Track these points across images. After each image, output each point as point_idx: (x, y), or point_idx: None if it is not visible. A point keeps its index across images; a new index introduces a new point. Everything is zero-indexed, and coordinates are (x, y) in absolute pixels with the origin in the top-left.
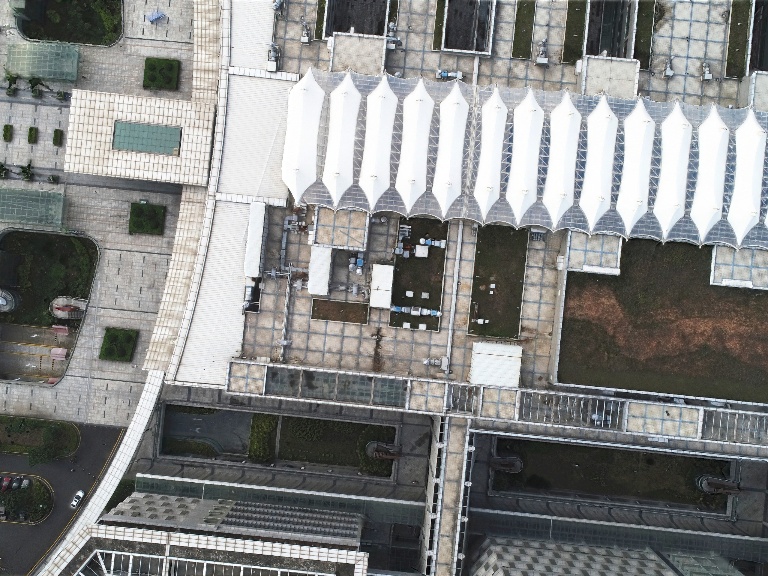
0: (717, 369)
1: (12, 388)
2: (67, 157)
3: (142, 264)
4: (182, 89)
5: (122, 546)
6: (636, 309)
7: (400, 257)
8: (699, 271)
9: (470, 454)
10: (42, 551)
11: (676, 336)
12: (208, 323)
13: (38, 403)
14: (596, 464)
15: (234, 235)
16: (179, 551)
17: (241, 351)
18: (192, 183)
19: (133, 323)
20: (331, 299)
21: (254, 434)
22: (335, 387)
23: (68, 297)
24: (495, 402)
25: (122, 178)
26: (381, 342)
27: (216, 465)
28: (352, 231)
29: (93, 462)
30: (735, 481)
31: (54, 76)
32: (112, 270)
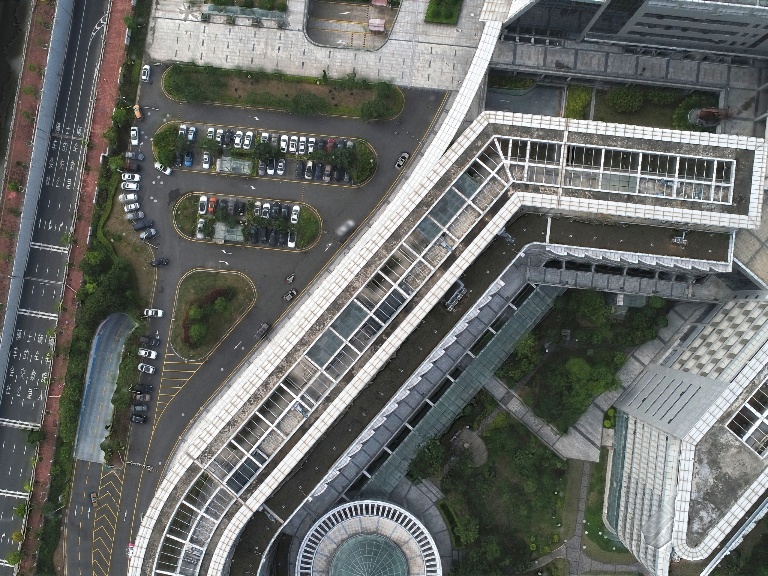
0: None
1: (335, 52)
2: None
3: None
4: None
5: (520, 132)
6: None
7: None
8: None
9: None
10: (365, 214)
11: None
12: None
13: (361, 67)
14: None
15: None
16: (577, 137)
17: None
18: None
19: None
20: None
21: (569, 108)
22: None
23: None
24: None
25: None
26: None
27: None
28: None
29: (417, 125)
30: None
31: None
32: None
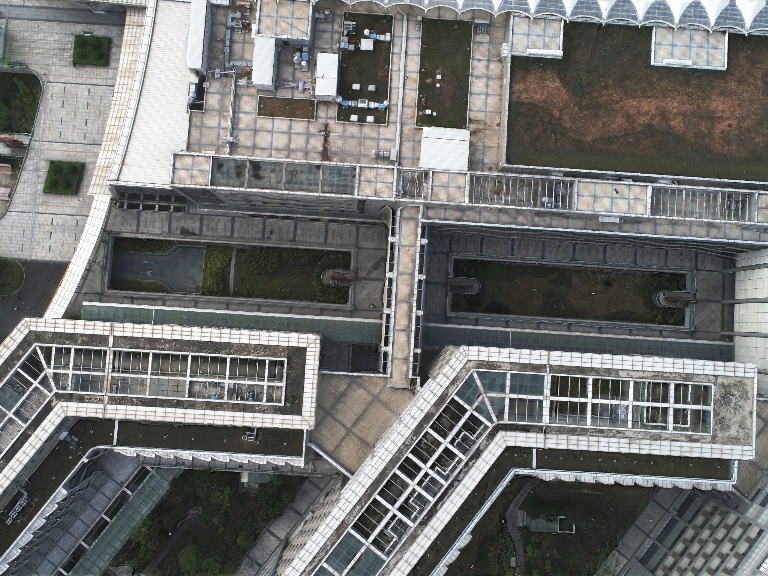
0: (663, 147)
1: None
2: None
3: (87, 96)
4: None
5: (63, 339)
6: (580, 90)
7: (346, 53)
8: (640, 53)
9: (423, 247)
10: None
11: (621, 116)
12: (151, 122)
13: None
14: (555, 288)
15: (177, 34)
16: (123, 342)
17: (186, 150)
18: (136, 3)
19: (78, 156)
20: (277, 96)
21: (207, 270)
22: (282, 176)
23: (11, 133)
24: (445, 186)
25: (64, 0)
26: (329, 138)
27: (167, 297)
28: (295, 21)
29: (38, 299)
30: (691, 292)
31: None
32: (56, 103)
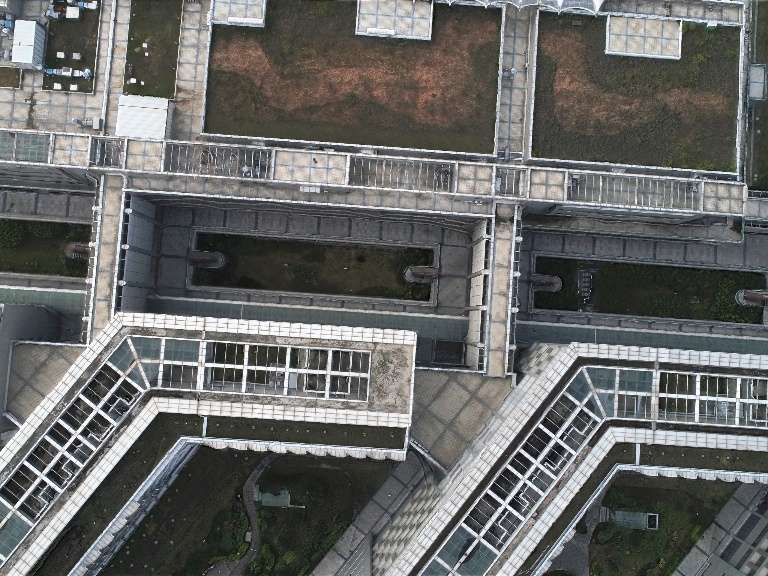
0: (365, 117)
1: None
2: None
3: None
4: None
5: None
6: (282, 59)
7: (54, 21)
8: (345, 22)
9: (127, 217)
10: None
11: (323, 86)
12: None
13: None
14: (307, 264)
15: None
16: None
17: None
18: None
19: None
20: None
21: None
22: None
23: None
24: (141, 154)
25: None
26: (35, 106)
27: None
28: None
29: None
30: (435, 267)
31: None
32: None
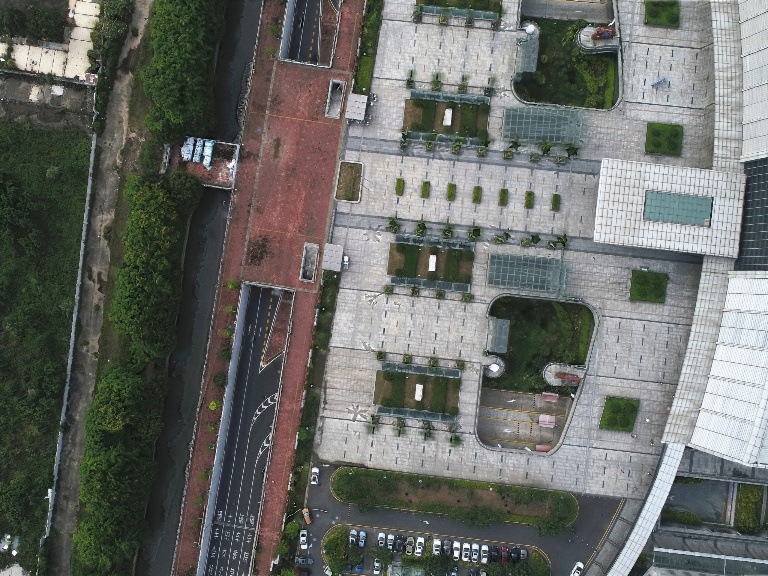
0: None
1: (507, 456)
2: (598, 227)
3: (642, 332)
4: (684, 155)
5: None
6: None
7: None
8: None
9: None
10: None
11: None
12: None
13: (534, 472)
14: None
15: None
16: None
17: None
18: (723, 255)
19: (633, 392)
20: None
21: (742, 504)
22: None
23: (561, 364)
24: None
25: None
26: None
27: (719, 538)
28: None
29: (591, 533)
30: None
31: (562, 141)
32: (611, 338)
